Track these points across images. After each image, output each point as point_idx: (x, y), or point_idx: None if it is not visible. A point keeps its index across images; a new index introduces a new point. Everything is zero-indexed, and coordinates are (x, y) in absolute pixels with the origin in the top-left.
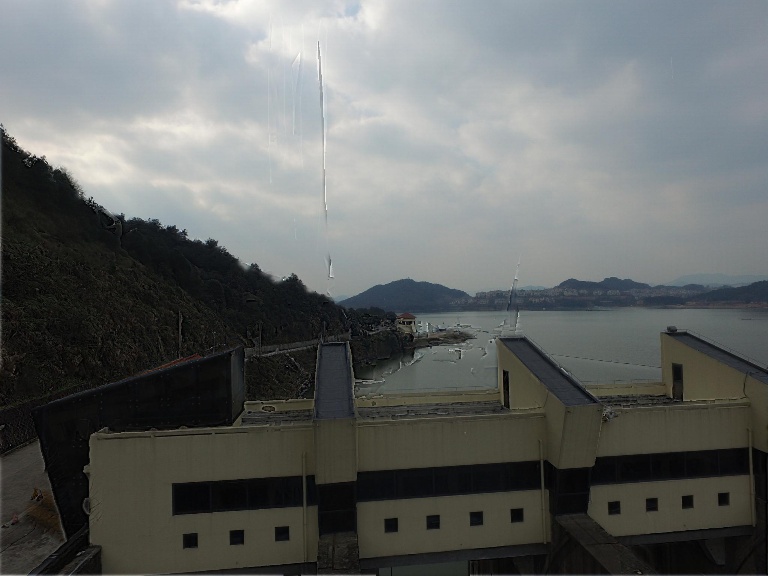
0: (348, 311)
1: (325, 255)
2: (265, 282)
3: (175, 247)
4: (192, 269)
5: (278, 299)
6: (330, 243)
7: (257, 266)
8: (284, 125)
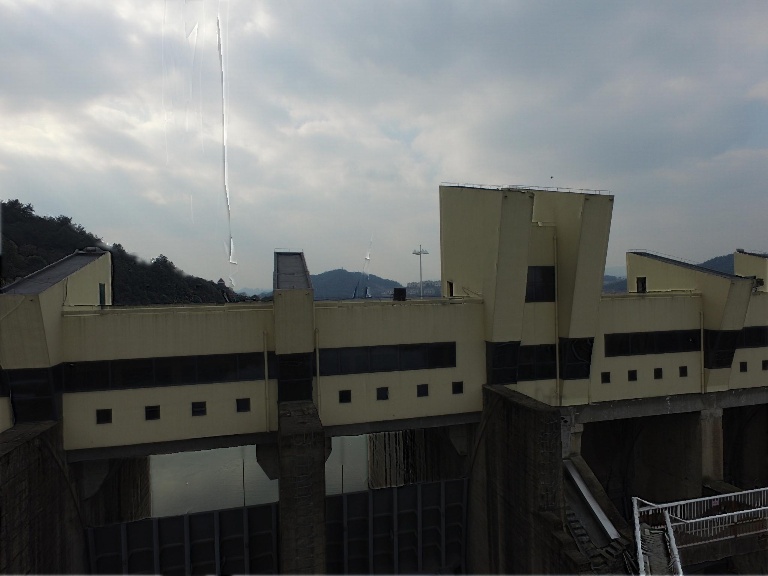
0: (232, 296)
1: (225, 240)
2: (123, 263)
3: (14, 223)
4: (6, 244)
5: (132, 280)
6: (231, 227)
7: (120, 246)
8: (182, 101)
